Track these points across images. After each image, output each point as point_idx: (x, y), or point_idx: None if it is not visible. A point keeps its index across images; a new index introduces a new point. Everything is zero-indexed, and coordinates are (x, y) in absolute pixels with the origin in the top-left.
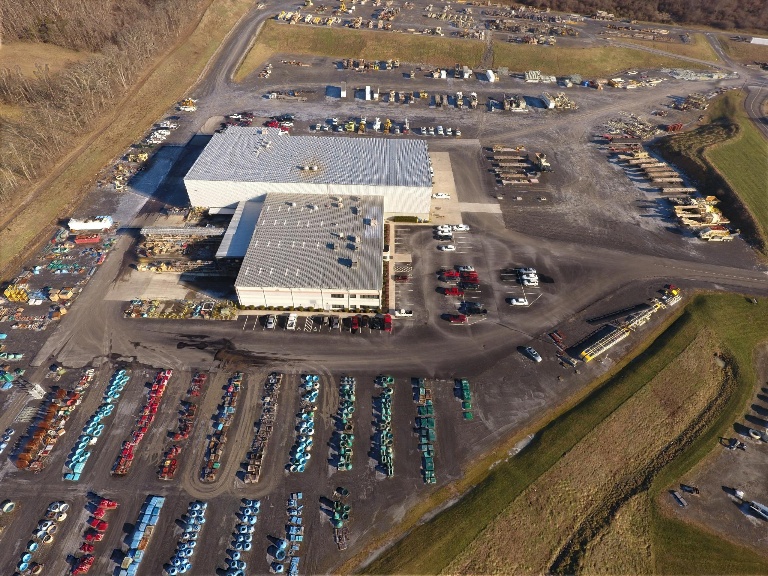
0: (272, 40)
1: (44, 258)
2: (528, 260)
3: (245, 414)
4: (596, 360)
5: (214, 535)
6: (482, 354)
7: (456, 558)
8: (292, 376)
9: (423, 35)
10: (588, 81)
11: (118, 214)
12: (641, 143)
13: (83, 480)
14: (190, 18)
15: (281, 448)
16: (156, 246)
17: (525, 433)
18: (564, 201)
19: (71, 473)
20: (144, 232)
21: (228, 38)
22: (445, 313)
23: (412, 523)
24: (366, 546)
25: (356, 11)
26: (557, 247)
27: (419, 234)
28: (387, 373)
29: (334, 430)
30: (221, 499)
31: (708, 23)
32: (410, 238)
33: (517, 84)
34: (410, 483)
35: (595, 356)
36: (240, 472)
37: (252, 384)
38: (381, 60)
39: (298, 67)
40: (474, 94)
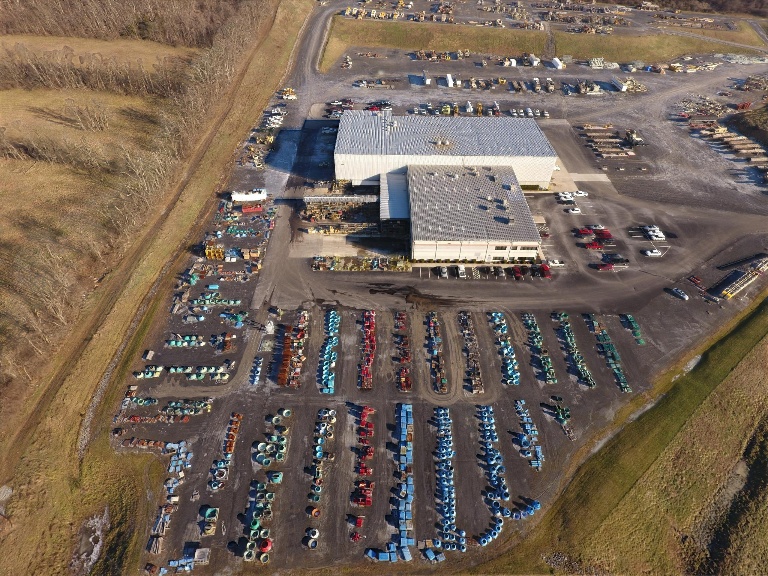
0: (343, 34)
1: (220, 225)
2: (648, 220)
3: (451, 343)
4: (735, 298)
5: (464, 431)
6: (635, 295)
7: (669, 445)
8: (479, 314)
9: (486, 27)
10: (650, 66)
11: (268, 188)
12: (716, 120)
13: (337, 393)
14: (265, 15)
15: (492, 368)
16: (315, 213)
17: (693, 354)
18: (663, 171)
19: (325, 388)
20: (307, 200)
21: (302, 33)
22: (591, 263)
23: (622, 421)
24: (591, 438)
25: (414, 6)
26: (670, 209)
27: (544, 200)
28: (559, 310)
29: (531, 354)
30: (458, 405)
31: (748, 11)
32: (537, 203)
33: (584, 70)
34: (610, 392)
35: (733, 295)
36: (466, 386)
37: (447, 320)
38: (449, 51)
39: (375, 59)
40: (550, 79)
